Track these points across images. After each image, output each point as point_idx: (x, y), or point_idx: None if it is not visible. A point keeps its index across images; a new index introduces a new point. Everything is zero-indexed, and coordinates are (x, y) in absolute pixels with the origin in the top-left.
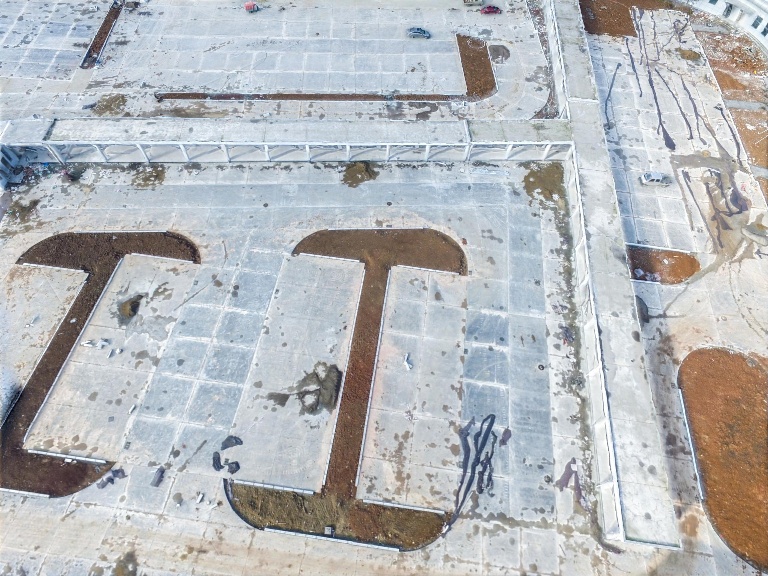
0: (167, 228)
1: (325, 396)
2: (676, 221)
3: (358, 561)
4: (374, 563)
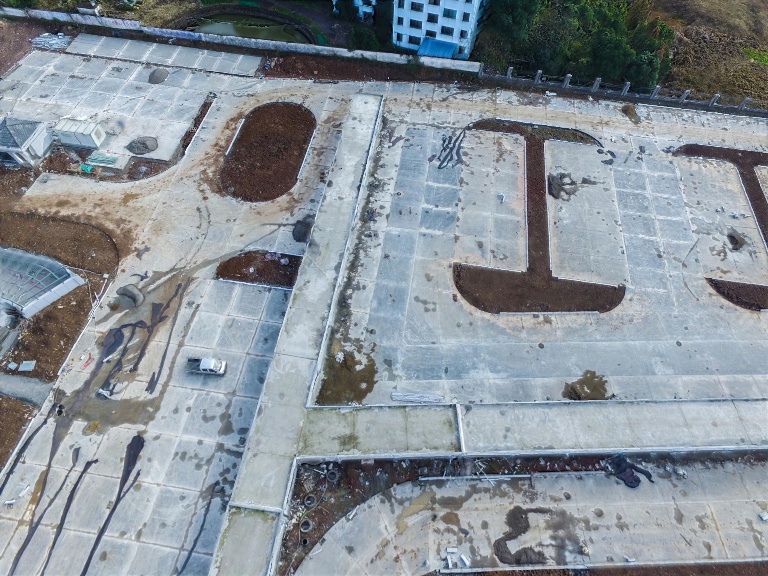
0: (763, 315)
1: (557, 181)
2: (211, 315)
3: (517, 116)
4: (509, 115)
